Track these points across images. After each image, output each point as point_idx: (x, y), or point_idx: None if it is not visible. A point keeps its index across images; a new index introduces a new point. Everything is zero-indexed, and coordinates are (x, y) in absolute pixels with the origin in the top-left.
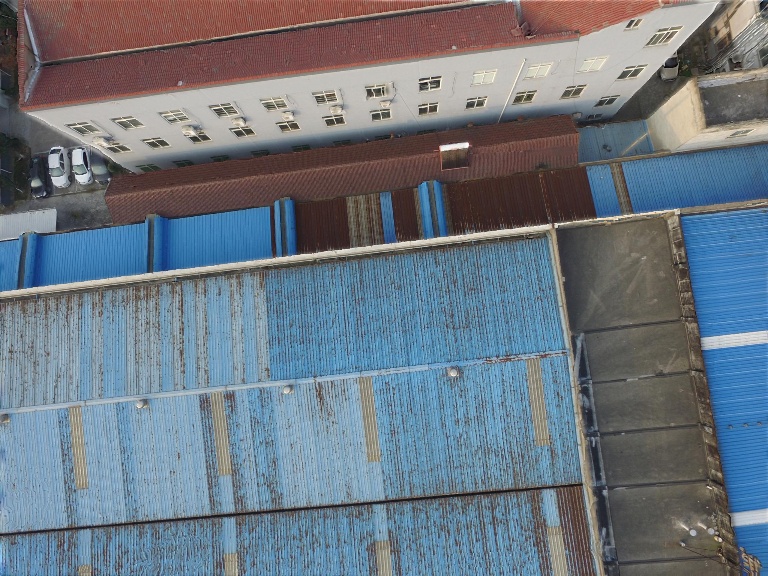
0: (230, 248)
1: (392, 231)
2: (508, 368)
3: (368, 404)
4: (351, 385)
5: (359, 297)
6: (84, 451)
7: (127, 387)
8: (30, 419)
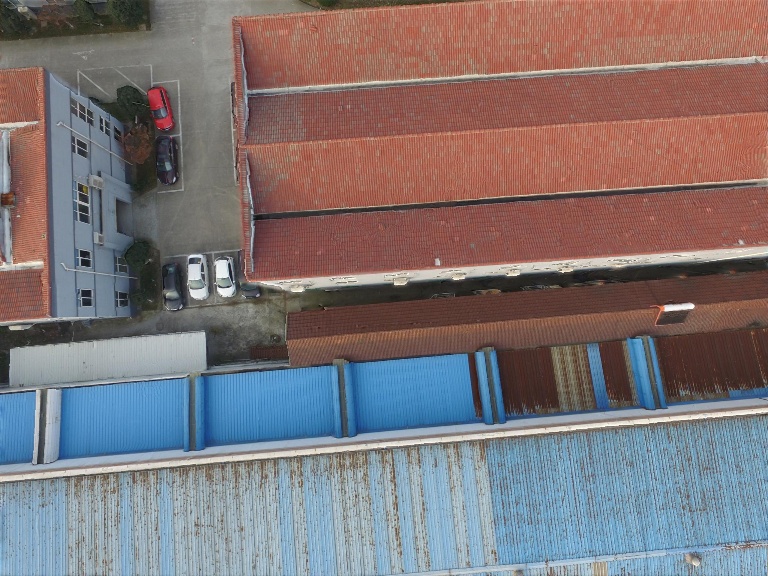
0: (427, 400)
1: (603, 388)
2: (747, 554)
3: None
4: (585, 570)
5: (589, 473)
6: None
7: (337, 569)
8: None
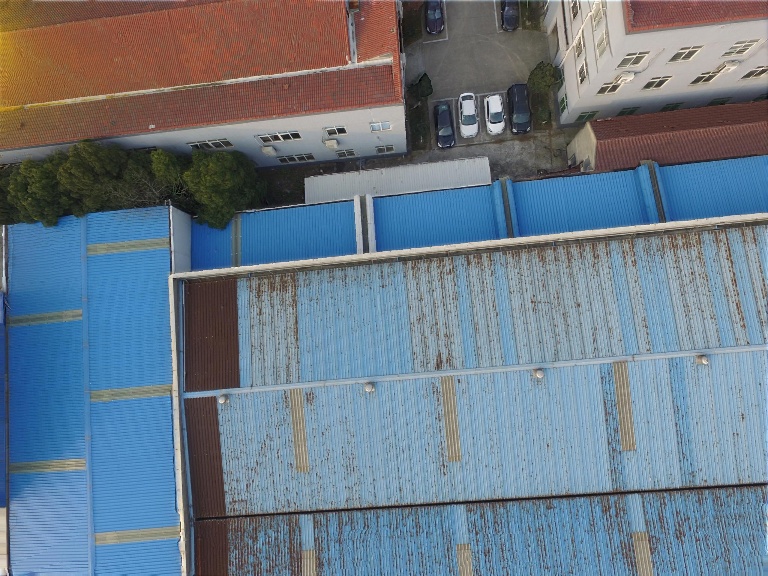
0: (738, 198)
1: None
2: None
3: None
4: None
5: None
6: (631, 410)
7: (679, 341)
8: (567, 374)
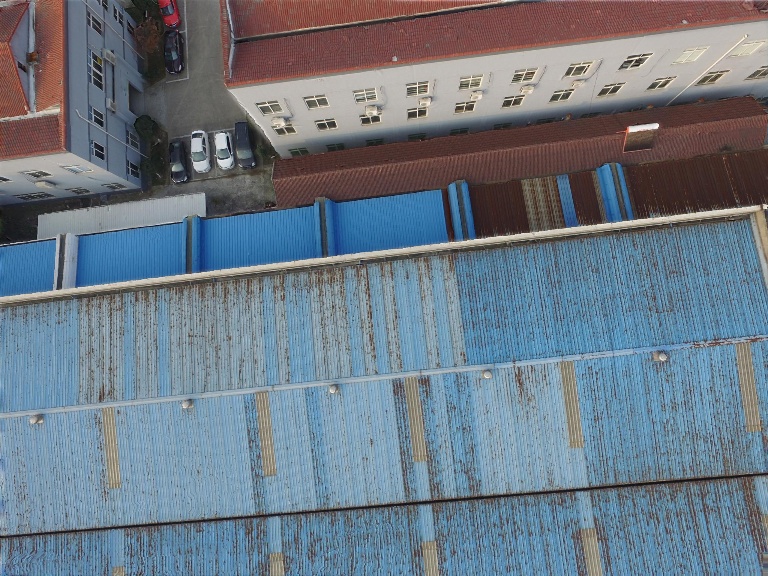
0: (403, 232)
1: (573, 214)
2: (717, 352)
3: (570, 389)
4: (552, 370)
5: (555, 280)
6: (272, 437)
7: (316, 372)
8: (215, 404)
